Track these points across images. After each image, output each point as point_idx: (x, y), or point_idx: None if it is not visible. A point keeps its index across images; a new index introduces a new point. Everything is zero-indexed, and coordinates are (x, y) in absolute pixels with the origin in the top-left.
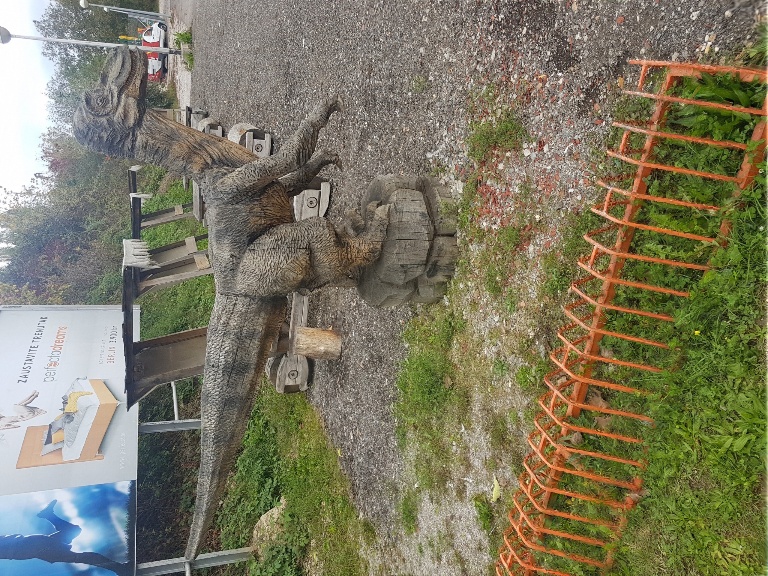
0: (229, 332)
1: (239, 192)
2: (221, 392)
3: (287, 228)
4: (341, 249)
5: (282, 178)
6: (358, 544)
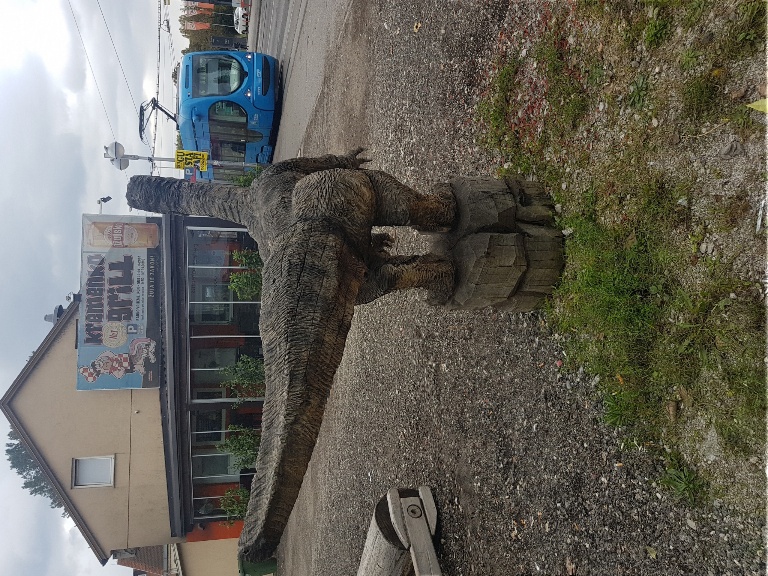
0: (291, 245)
1: (282, 164)
2: (290, 290)
3: None
4: None
5: None
6: None
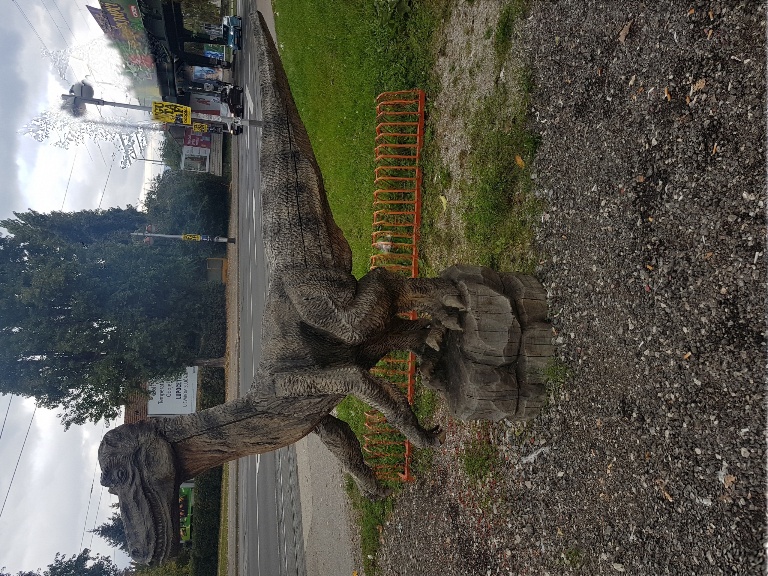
0: None
1: None
2: None
3: None
4: None
5: None
6: None
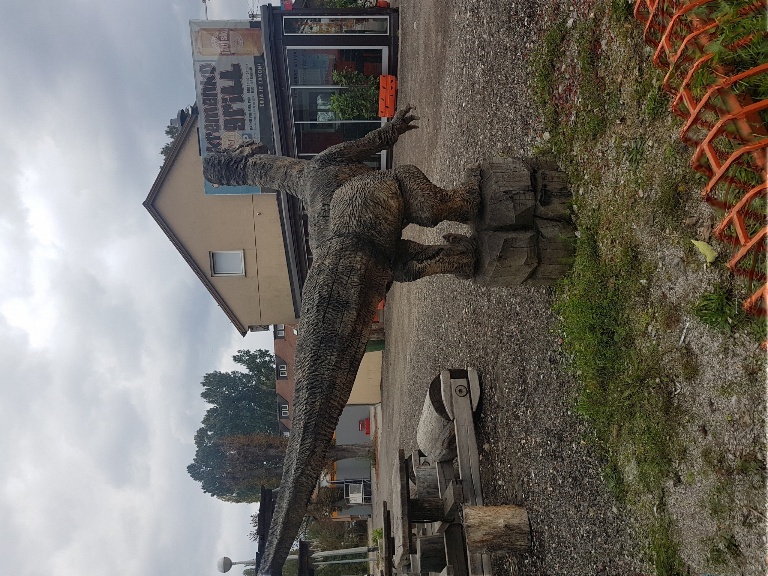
0: (324, 270)
1: (327, 156)
2: (316, 329)
3: None
4: None
5: None
6: None
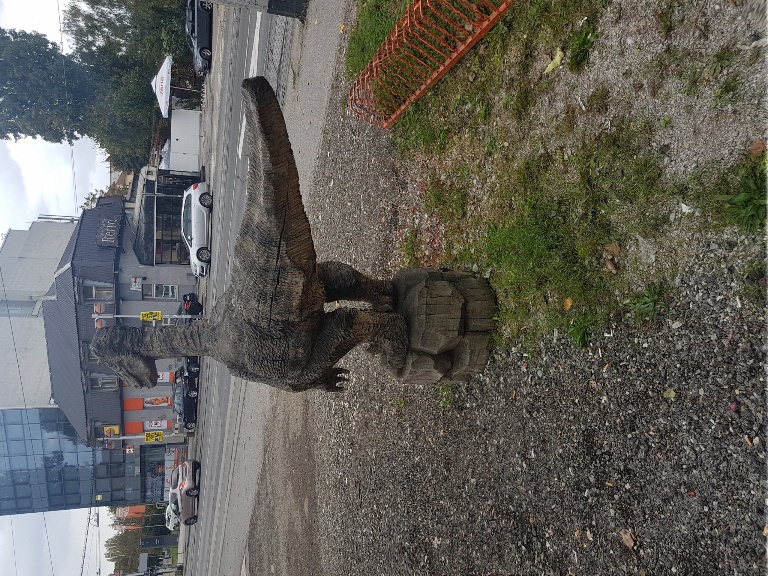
0: None
1: None
2: None
3: None
4: None
5: None
6: None
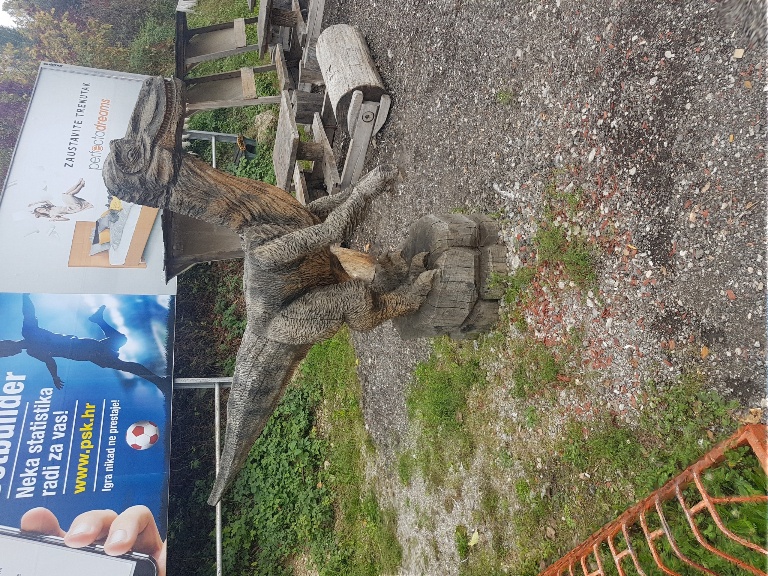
0: (257, 365)
1: (277, 266)
2: (246, 405)
3: (323, 298)
4: (376, 313)
5: (328, 200)
6: (361, 443)
